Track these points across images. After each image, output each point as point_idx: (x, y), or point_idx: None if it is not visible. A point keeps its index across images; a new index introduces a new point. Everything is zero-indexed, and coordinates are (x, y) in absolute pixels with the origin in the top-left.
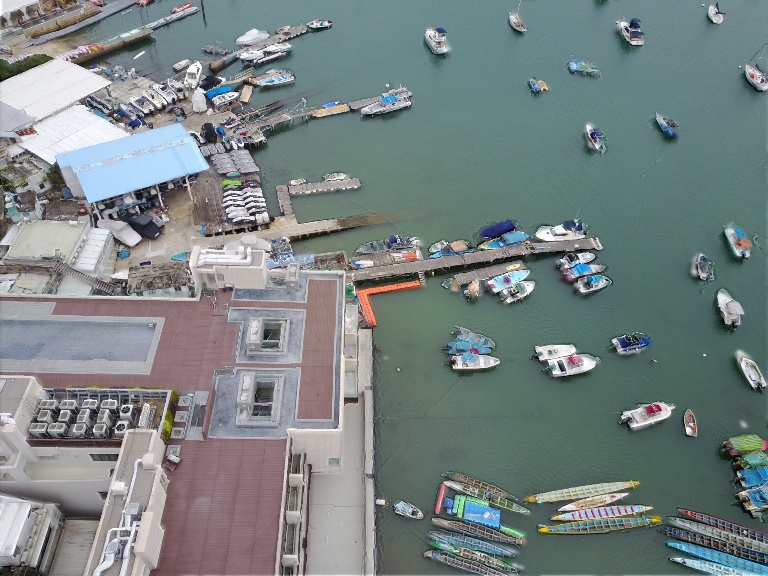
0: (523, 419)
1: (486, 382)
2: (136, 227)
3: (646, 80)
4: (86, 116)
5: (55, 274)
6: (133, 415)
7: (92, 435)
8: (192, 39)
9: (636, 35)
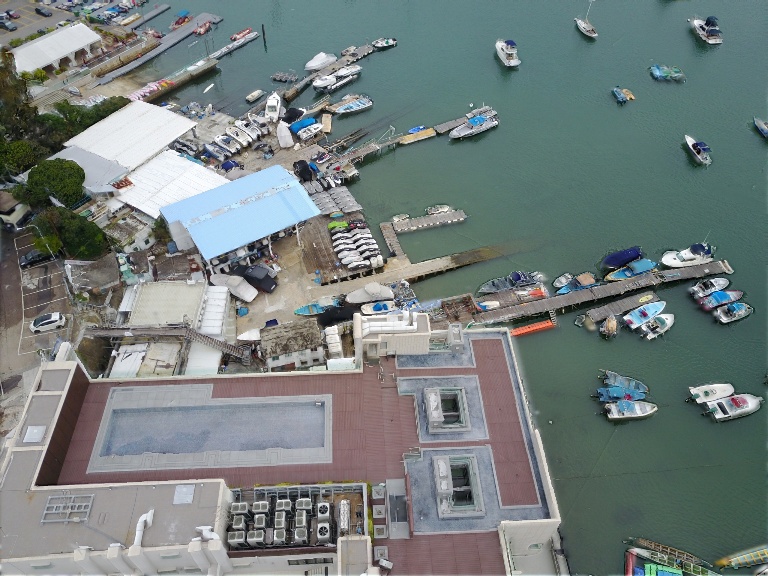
0: (696, 472)
1: (645, 431)
2: (252, 281)
3: (730, 80)
4: (179, 162)
5: (186, 342)
6: (330, 514)
7: (289, 539)
8: (258, 67)
9: (713, 33)
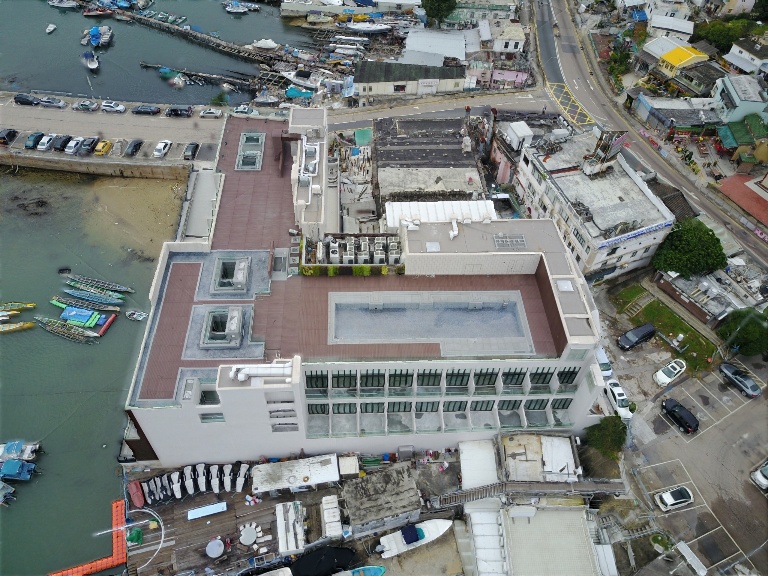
0: None
1: (8, 438)
2: None
3: None
4: None
5: None
6: None
7: (359, 249)
8: None
9: None
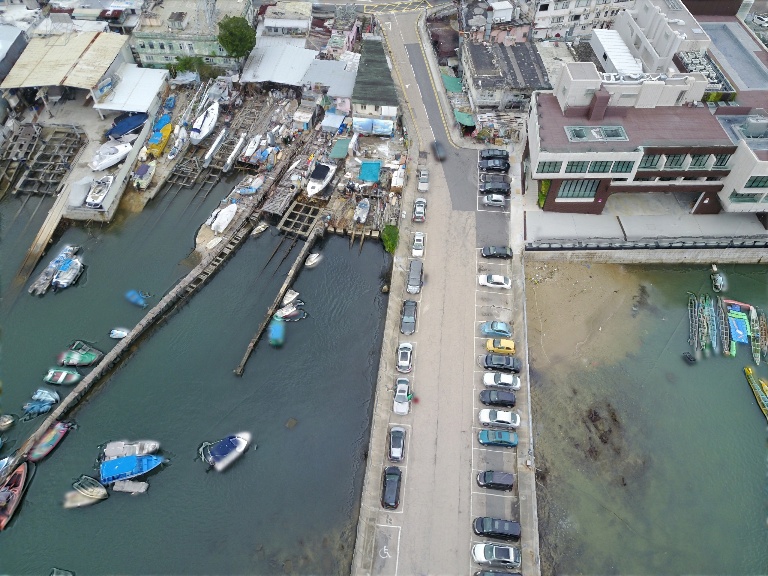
0: None
1: None
2: None
3: None
4: None
5: None
6: None
7: None
8: None
9: None
